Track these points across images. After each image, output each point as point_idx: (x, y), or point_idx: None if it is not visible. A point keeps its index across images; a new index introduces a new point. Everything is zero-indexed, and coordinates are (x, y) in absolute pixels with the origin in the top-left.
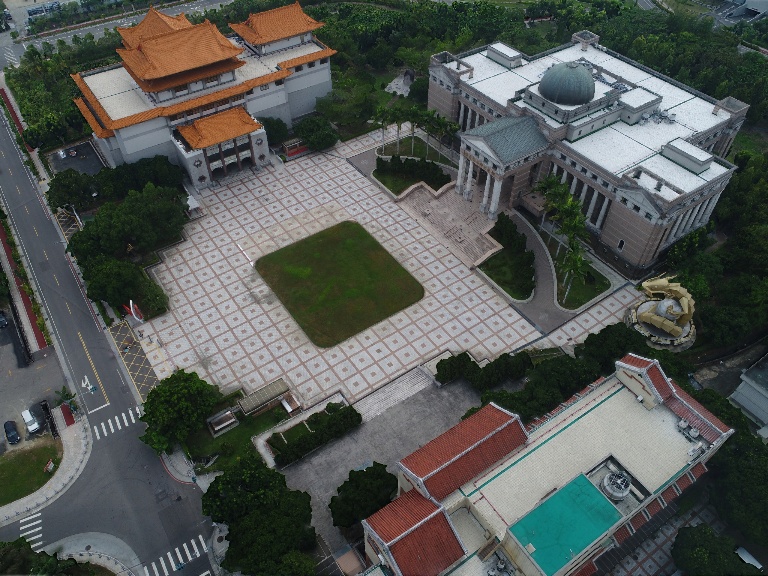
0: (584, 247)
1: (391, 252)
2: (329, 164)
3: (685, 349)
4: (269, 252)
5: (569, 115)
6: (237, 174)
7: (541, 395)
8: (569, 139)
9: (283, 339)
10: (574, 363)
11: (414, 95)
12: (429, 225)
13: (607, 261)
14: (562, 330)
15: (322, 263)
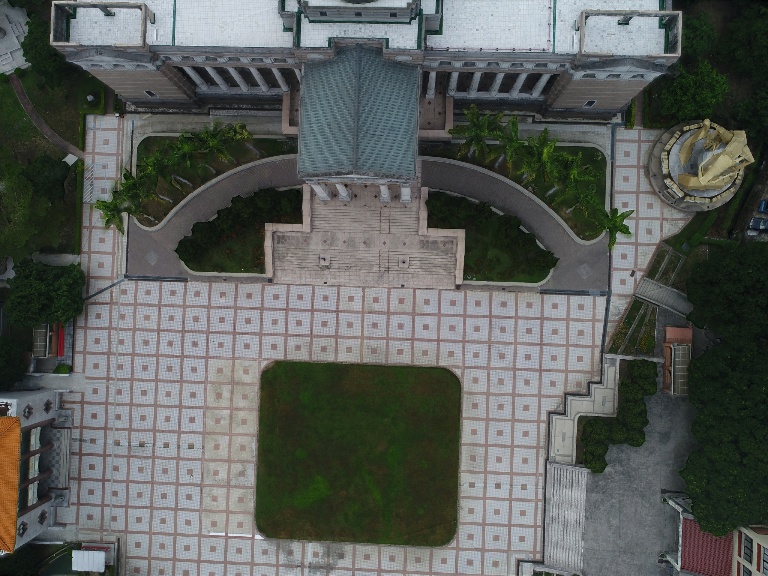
0: (525, 121)
1: (360, 360)
2: (121, 311)
3: (743, 174)
4: (252, 505)
5: (417, 5)
6: (55, 453)
7: (761, 454)
8: (433, 30)
9: (408, 575)
10: (762, 393)
11: (56, 76)
12: (347, 275)
13: (567, 117)
14: (616, 270)
15: (320, 456)
